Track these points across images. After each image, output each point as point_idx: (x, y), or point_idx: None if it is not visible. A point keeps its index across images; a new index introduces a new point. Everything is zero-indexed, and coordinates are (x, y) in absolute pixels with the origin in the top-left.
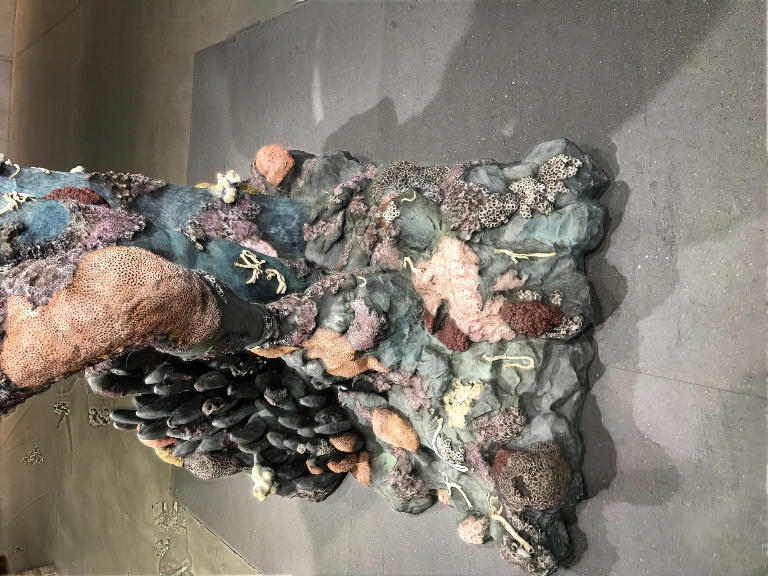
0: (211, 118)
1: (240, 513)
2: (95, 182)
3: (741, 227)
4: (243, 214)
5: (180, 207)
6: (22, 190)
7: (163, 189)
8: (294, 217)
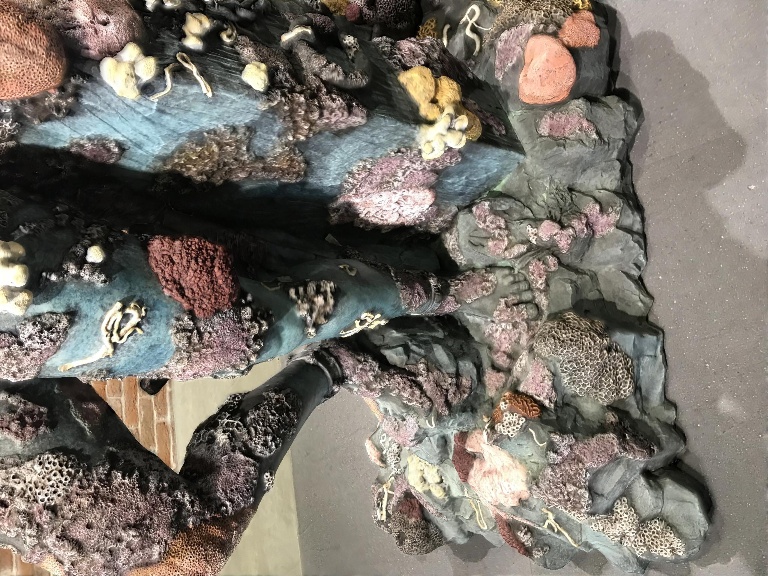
0: None
1: None
2: (271, 111)
3: None
4: (433, 165)
5: (362, 147)
6: (161, 116)
7: (357, 126)
8: (491, 170)
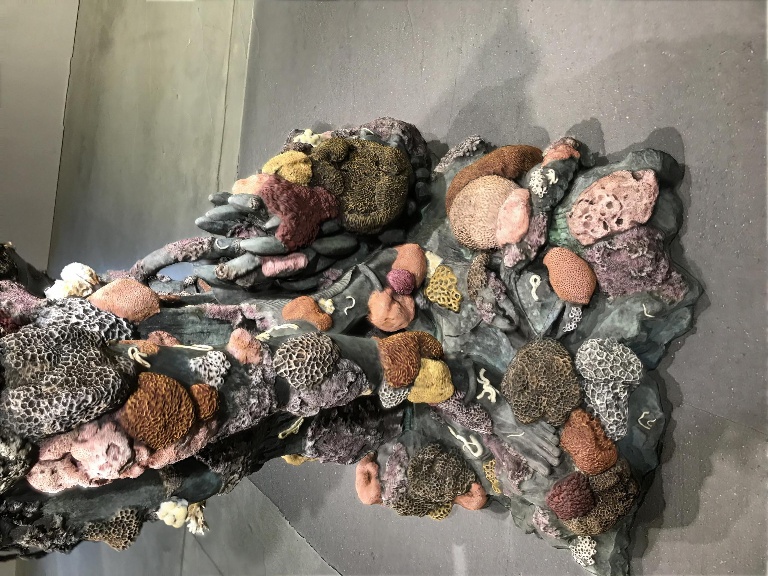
0: None
1: None
2: None
3: None
4: None
5: None
6: None
7: None
8: None
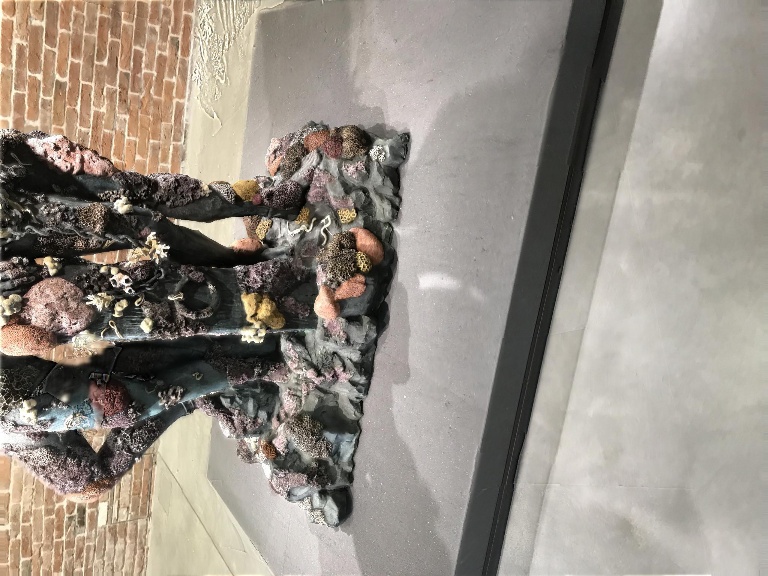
0: (495, 14)
1: (256, 141)
2: None
3: (320, 568)
4: None
5: None
6: None
7: None
8: None
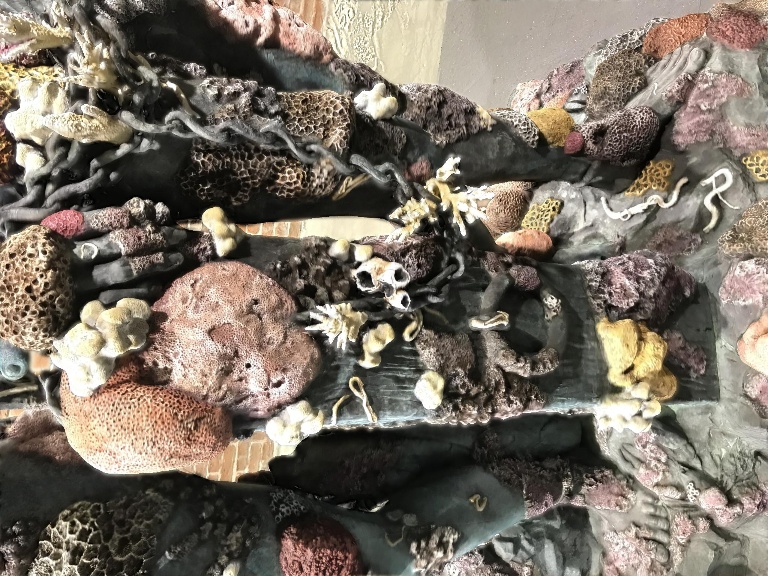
0: None
1: None
2: None
3: None
4: None
5: None
6: None
7: None
8: None
